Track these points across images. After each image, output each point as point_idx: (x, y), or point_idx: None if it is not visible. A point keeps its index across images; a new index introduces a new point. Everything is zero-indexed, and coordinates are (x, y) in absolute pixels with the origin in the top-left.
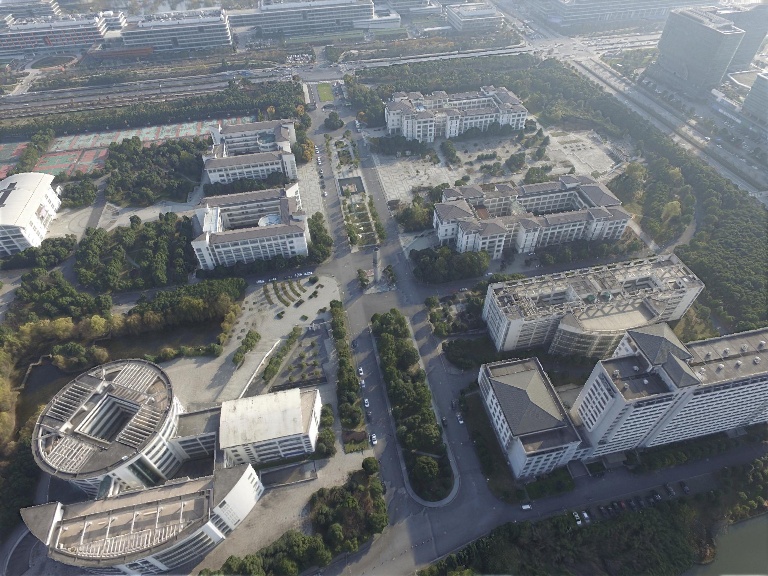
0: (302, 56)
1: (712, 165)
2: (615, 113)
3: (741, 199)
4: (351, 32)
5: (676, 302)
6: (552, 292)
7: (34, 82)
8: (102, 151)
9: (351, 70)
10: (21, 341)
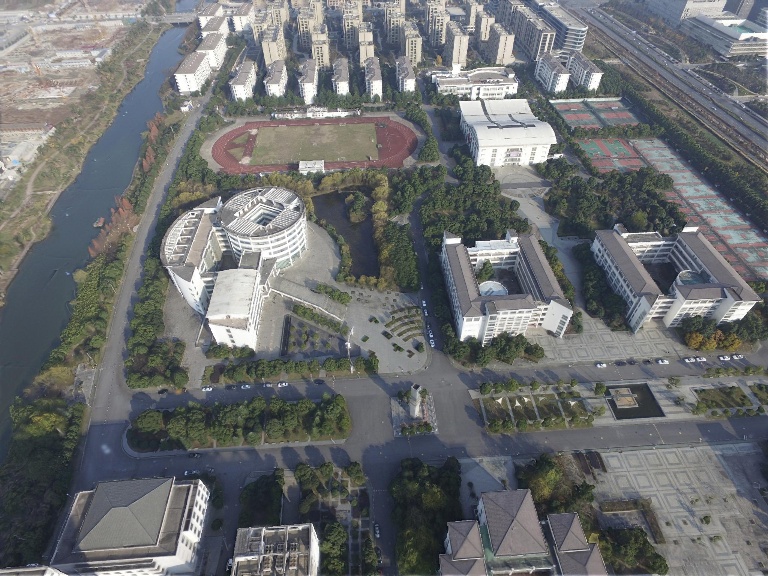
0: None
1: None
2: None
3: None
4: None
5: None
6: None
7: (767, 101)
8: None
9: None
10: (371, 178)
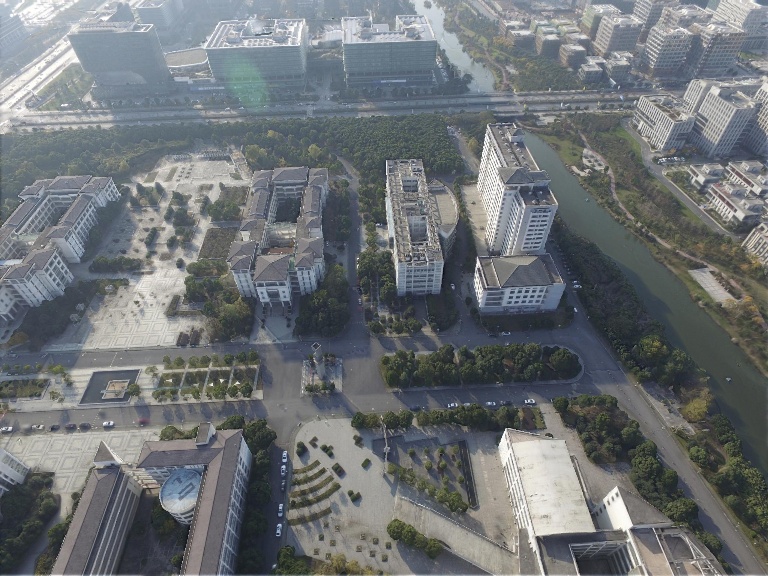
0: None
1: None
2: (155, 133)
3: (316, 122)
4: None
5: None
6: None
7: None
8: None
9: None
10: None
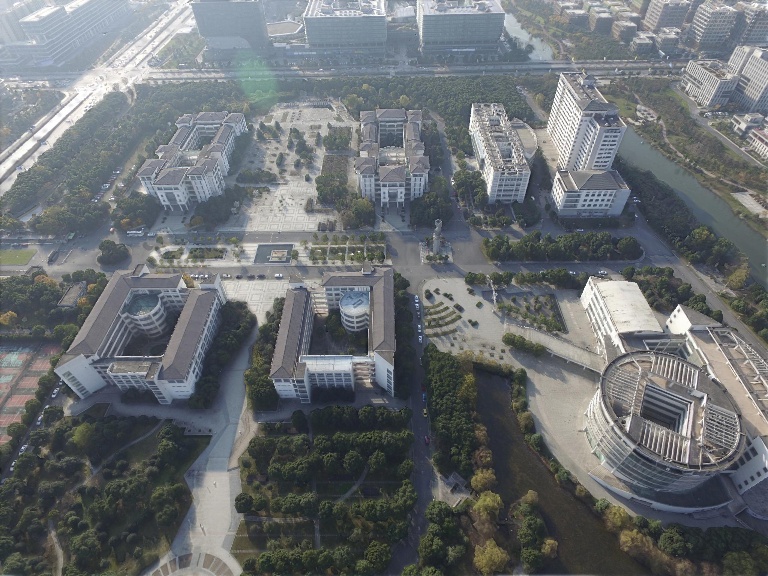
0: None
1: None
2: (266, 86)
3: None
4: None
5: None
6: None
7: None
8: None
9: None
10: None
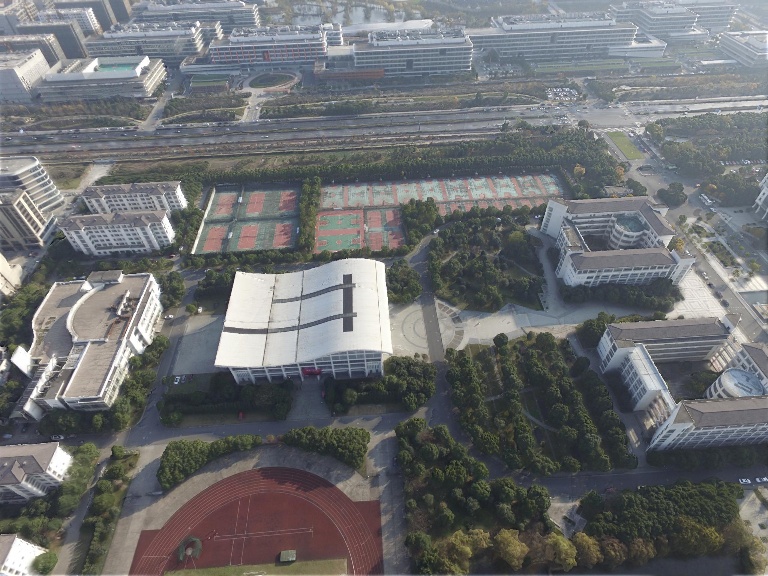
0: (563, 90)
1: None
2: None
3: None
4: (610, 61)
5: None
6: None
7: (262, 106)
8: (388, 213)
9: None
10: (463, 570)
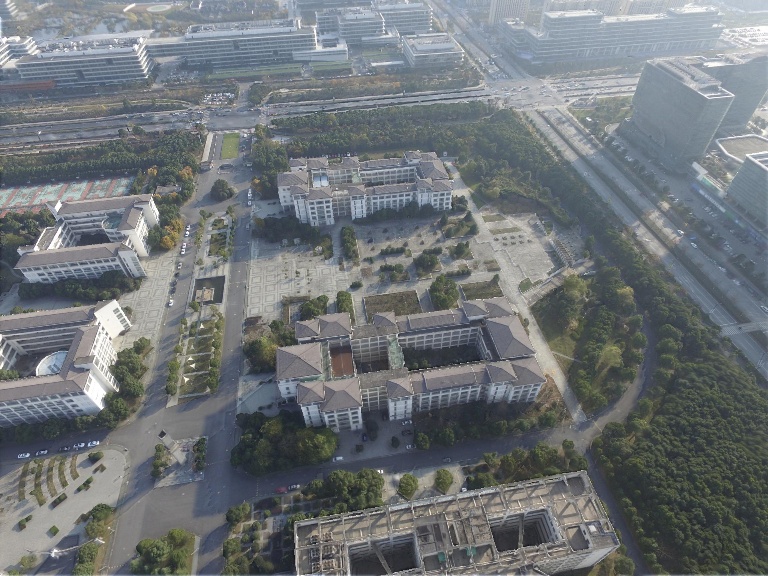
0: (223, 95)
1: (680, 276)
2: (567, 191)
3: (710, 341)
4: (288, 66)
5: (579, 559)
6: (390, 536)
7: None
8: None
9: (270, 116)
10: None
